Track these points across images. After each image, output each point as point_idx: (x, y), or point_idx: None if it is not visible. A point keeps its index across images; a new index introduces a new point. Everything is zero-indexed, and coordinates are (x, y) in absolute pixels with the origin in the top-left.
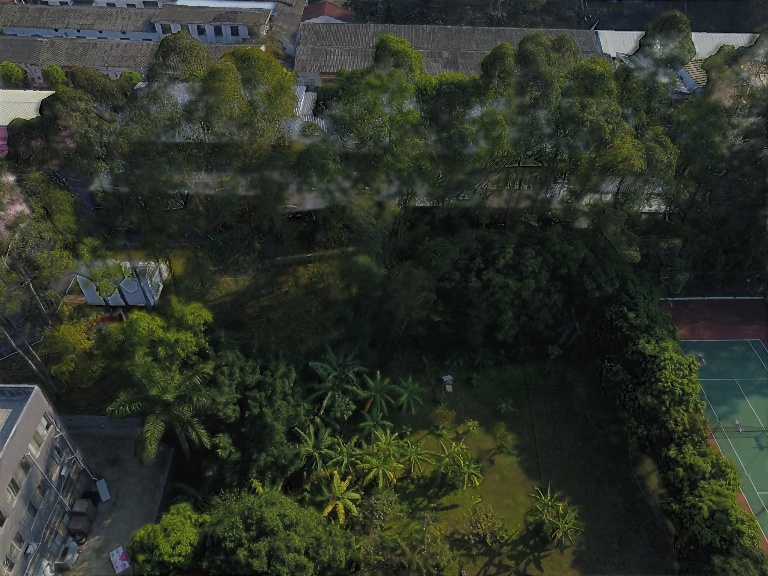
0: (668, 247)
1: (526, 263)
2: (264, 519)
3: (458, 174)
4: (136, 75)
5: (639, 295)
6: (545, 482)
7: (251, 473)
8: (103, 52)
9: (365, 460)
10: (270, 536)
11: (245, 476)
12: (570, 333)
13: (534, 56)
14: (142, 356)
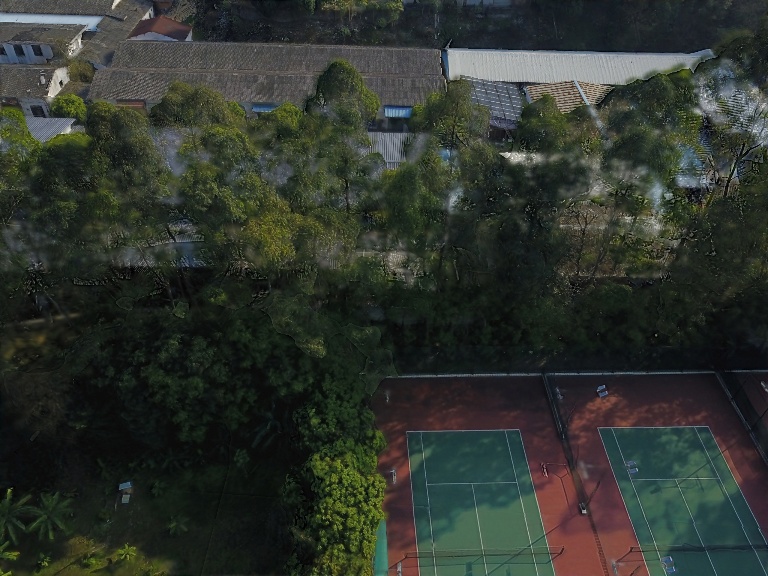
0: (361, 338)
1: (191, 357)
2: None
3: (60, 262)
4: None
5: (332, 394)
6: None
7: None
8: None
9: None
10: None
11: None
12: (266, 434)
13: (117, 122)
14: None
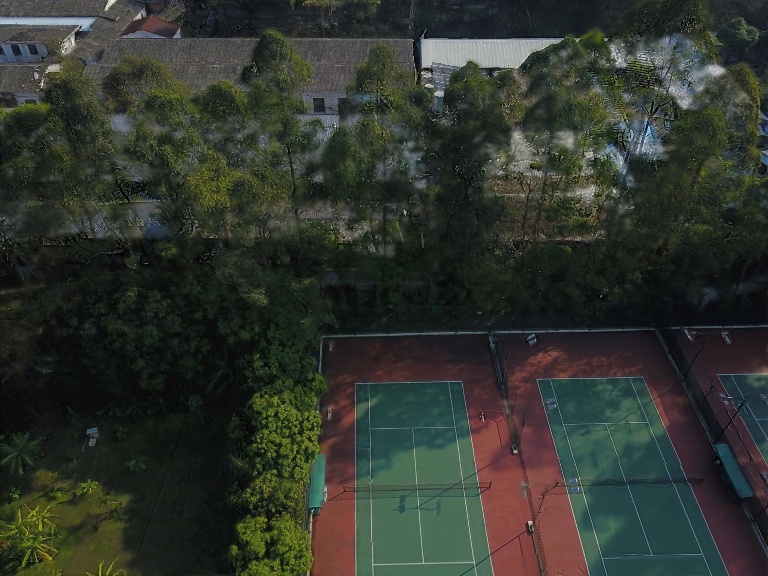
0: (299, 288)
1: (146, 308)
2: None
3: (20, 216)
4: None
5: (276, 341)
6: (142, 553)
7: None
8: None
9: None
10: None
11: None
12: (219, 381)
13: (64, 87)
14: None
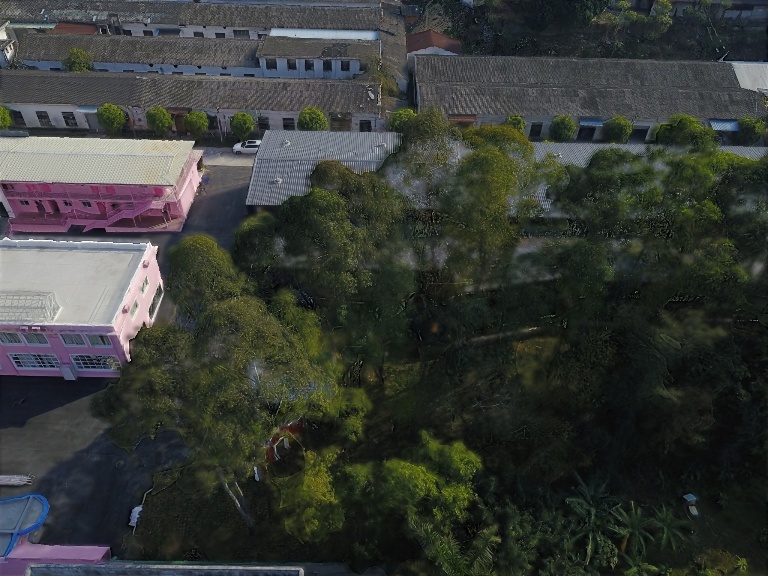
0: None
1: None
2: None
3: (759, 281)
4: (249, 118)
5: None
6: None
7: None
8: (210, 92)
9: None
10: None
11: None
12: None
13: None
14: (419, 523)
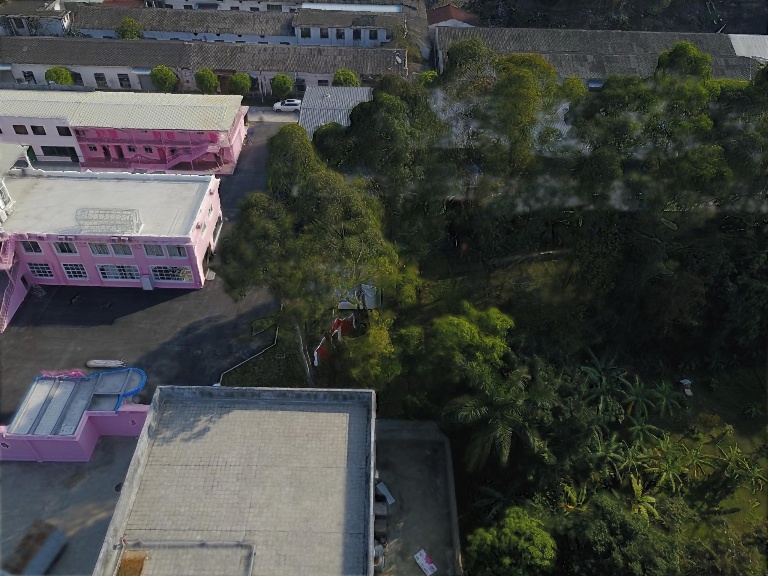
0: None
1: None
2: (628, 523)
3: (743, 180)
4: (288, 79)
5: None
6: None
7: (558, 477)
8: (252, 56)
9: (652, 464)
10: (633, 540)
11: (553, 480)
12: None
13: None
14: (465, 361)
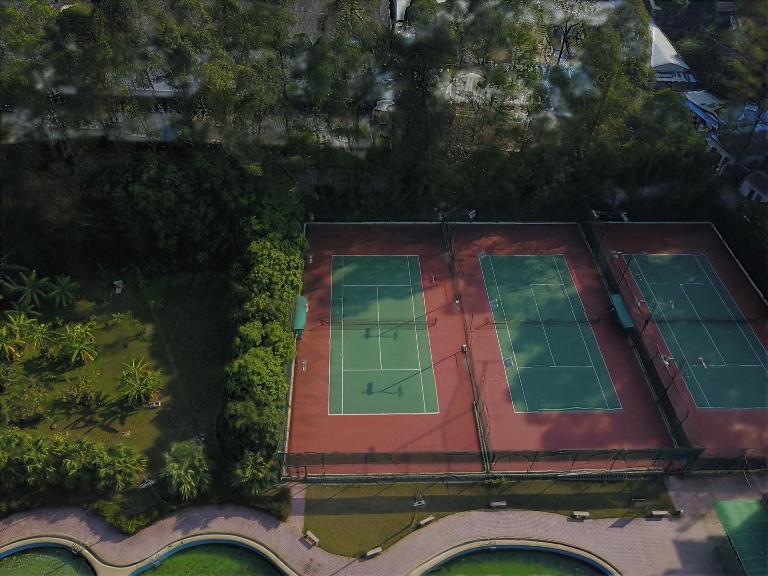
0: (288, 163)
1: (166, 176)
2: None
3: (71, 91)
4: None
5: (269, 206)
6: (163, 361)
7: None
8: None
9: None
10: None
11: None
12: (222, 242)
13: None
14: None
